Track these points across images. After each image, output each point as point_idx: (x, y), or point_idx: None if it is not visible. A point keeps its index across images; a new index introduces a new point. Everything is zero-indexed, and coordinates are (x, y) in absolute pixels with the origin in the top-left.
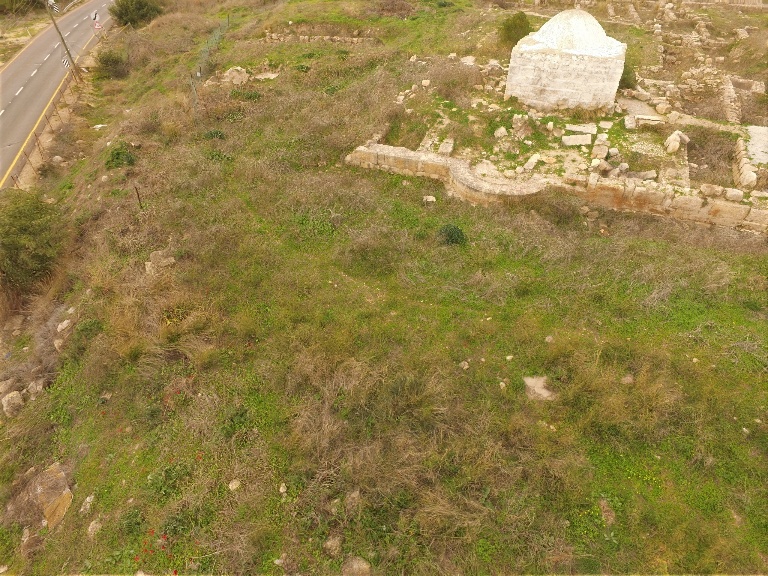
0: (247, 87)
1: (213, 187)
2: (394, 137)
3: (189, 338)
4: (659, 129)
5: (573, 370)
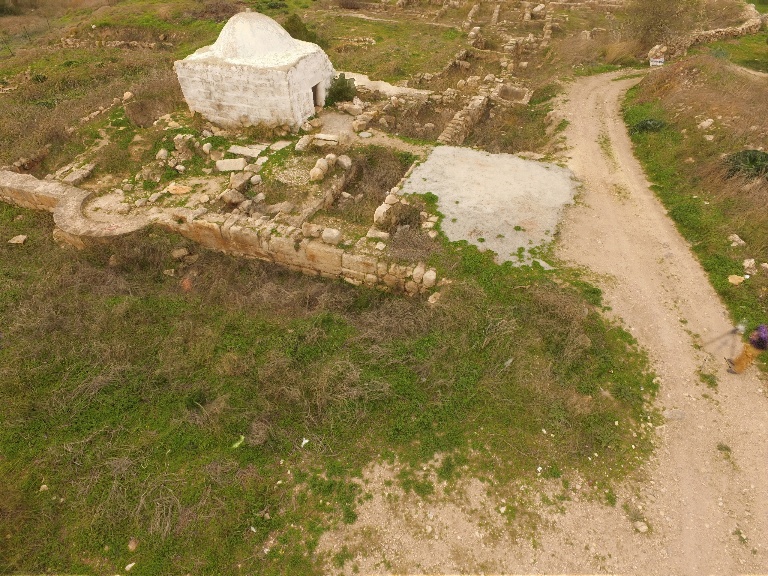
0: None
1: None
2: (52, 161)
3: None
4: (324, 151)
5: None
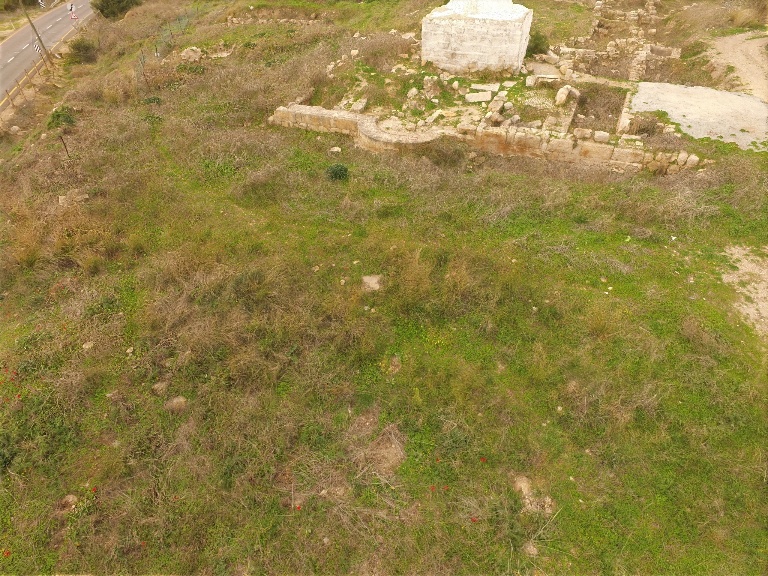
0: (195, 62)
1: (138, 141)
2: (317, 100)
3: (81, 249)
4: (554, 85)
5: (400, 266)
